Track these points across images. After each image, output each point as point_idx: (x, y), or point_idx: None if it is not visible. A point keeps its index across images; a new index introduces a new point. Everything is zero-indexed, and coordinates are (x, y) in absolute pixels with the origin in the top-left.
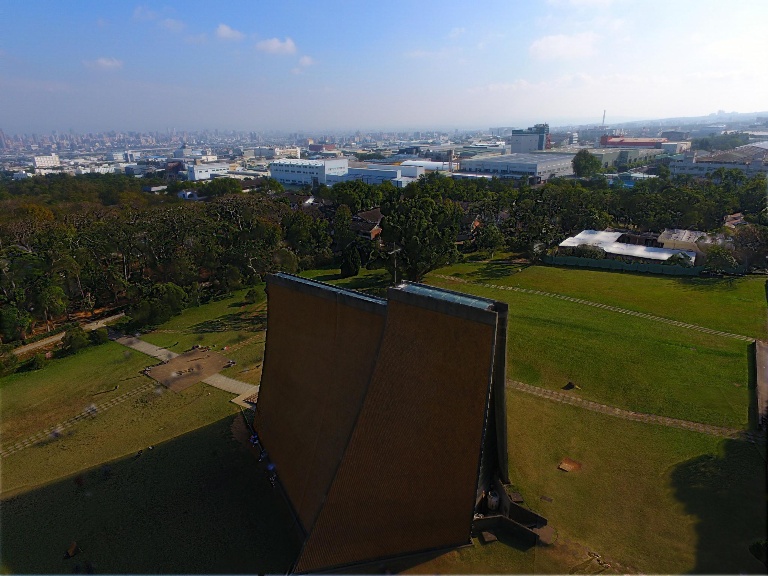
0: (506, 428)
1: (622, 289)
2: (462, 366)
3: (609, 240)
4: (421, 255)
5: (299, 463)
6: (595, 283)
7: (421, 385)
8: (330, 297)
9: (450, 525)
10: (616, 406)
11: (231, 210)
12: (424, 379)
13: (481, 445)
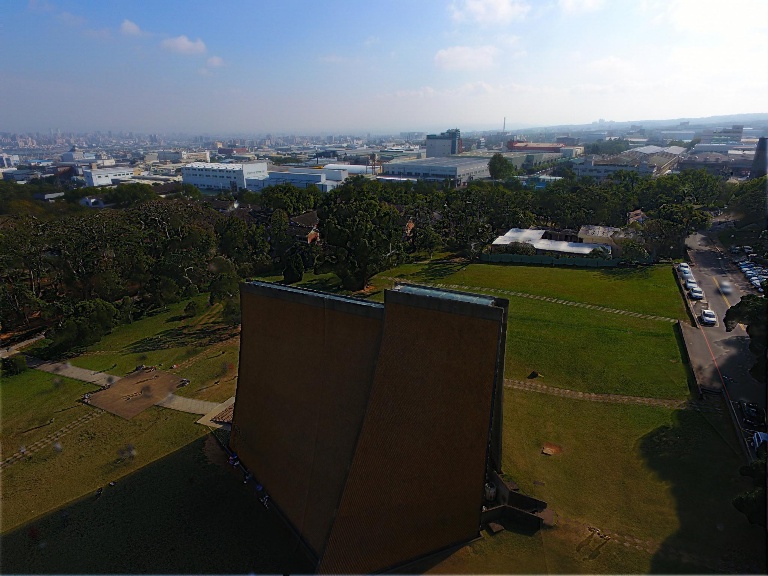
0: None
1: (556, 282)
2: (467, 363)
3: (535, 237)
4: (368, 258)
5: (294, 479)
6: (532, 277)
7: (426, 385)
8: (317, 303)
9: (461, 521)
10: (578, 390)
11: (157, 217)
12: (428, 379)
13: (488, 438)
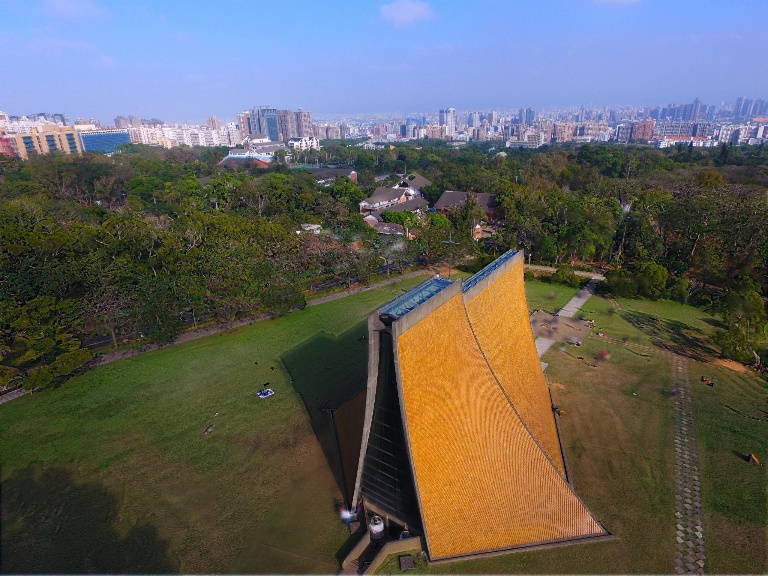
0: (414, 478)
1: None
2: None
3: None
4: None
5: None
6: None
7: None
8: None
9: None
10: None
11: None
12: None
13: None
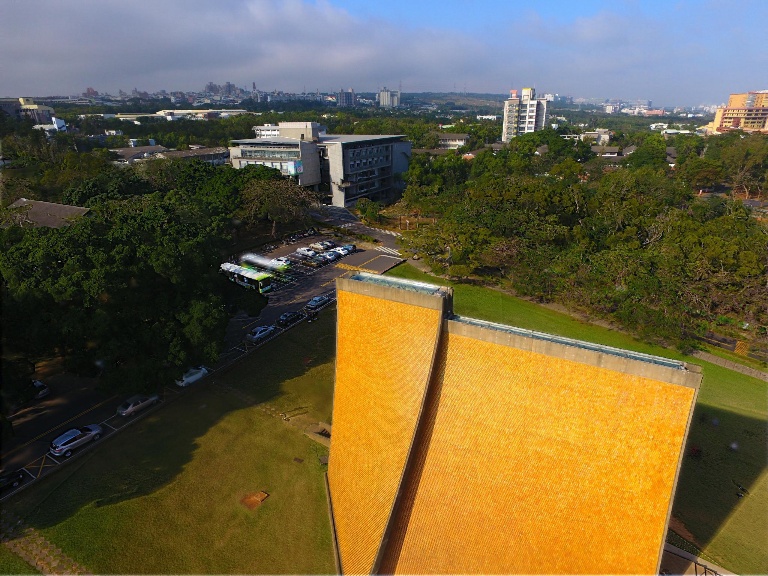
0: None
1: None
2: None
3: None
4: None
5: None
6: None
7: None
8: None
9: None
10: None
11: None
12: None
13: None
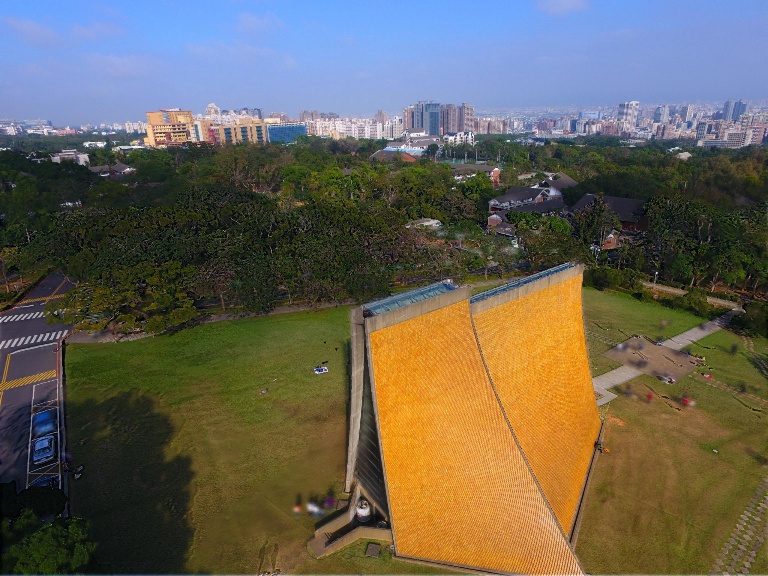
0: (383, 471)
1: None
2: None
3: None
4: None
5: None
6: None
7: None
8: None
9: None
10: None
11: None
12: None
13: None
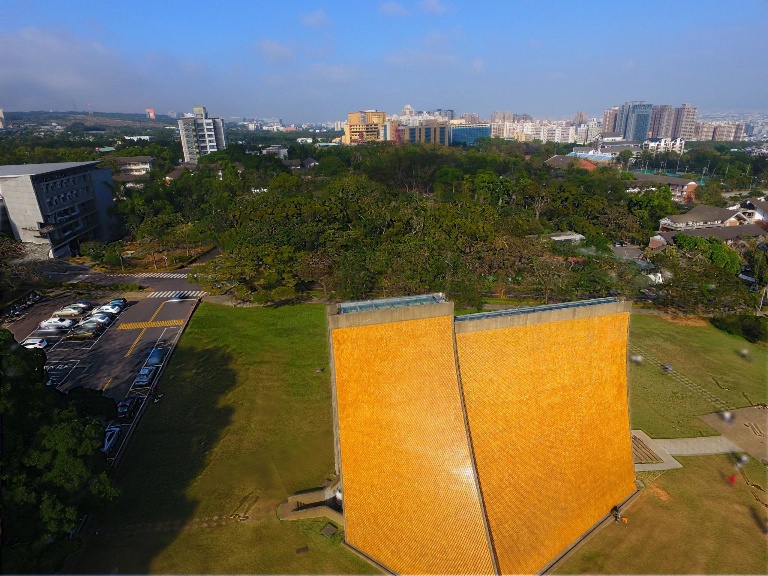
0: (340, 460)
1: None
2: None
3: None
4: None
5: None
6: None
7: None
8: None
9: None
10: None
11: None
12: None
13: None
